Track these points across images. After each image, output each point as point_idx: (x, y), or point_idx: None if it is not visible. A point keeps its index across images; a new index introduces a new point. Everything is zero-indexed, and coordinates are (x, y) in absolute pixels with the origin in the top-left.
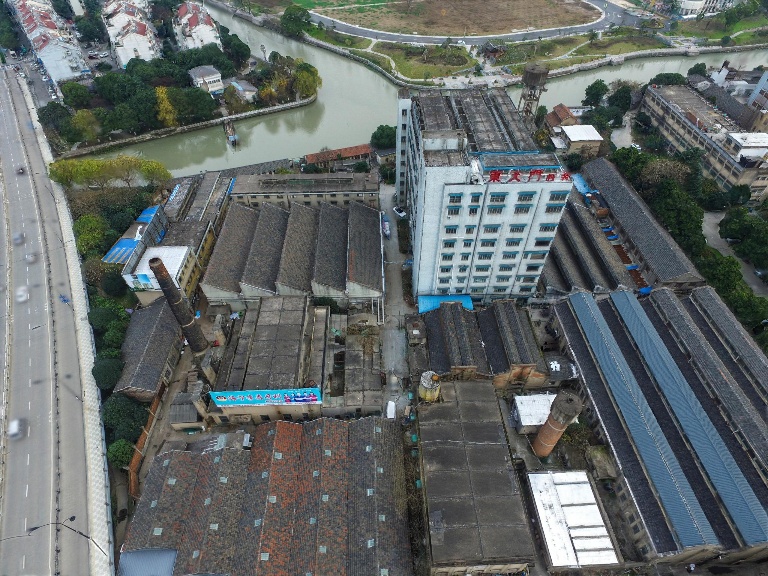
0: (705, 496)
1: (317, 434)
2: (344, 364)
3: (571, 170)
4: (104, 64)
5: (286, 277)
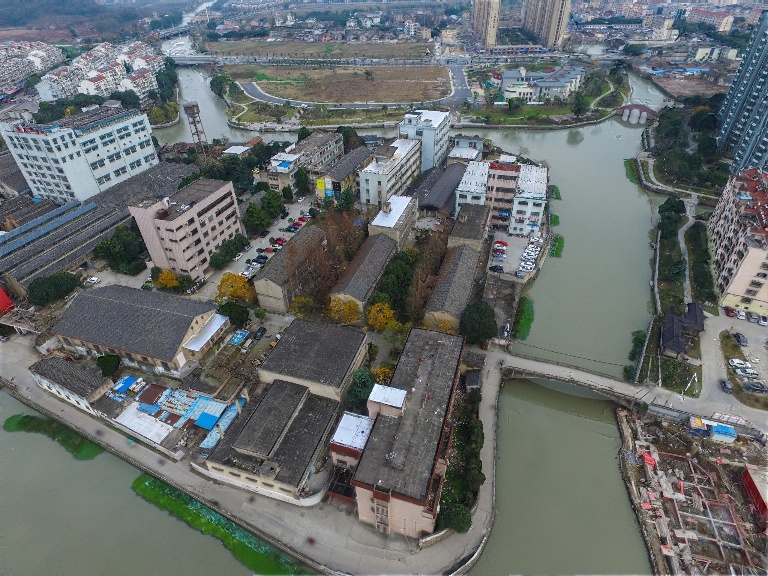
0: None
1: None
2: None
3: None
4: None
5: None
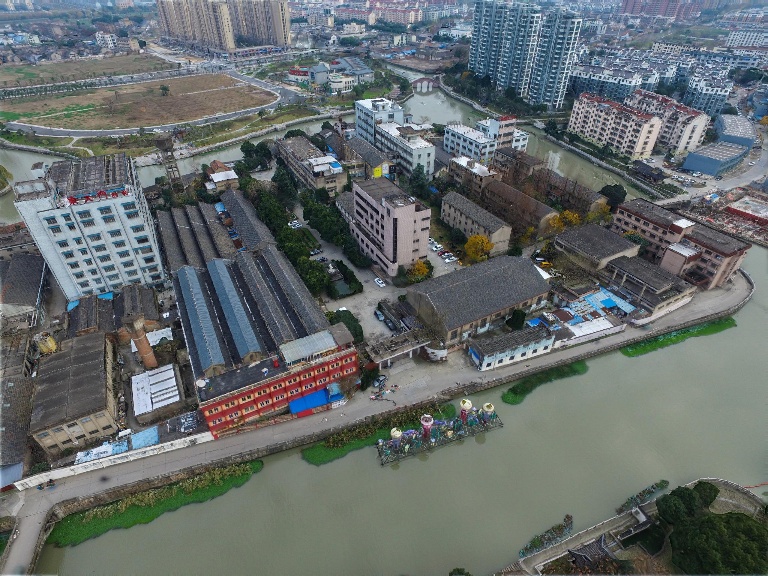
0: (233, 348)
1: None
2: None
3: None
4: None
5: None
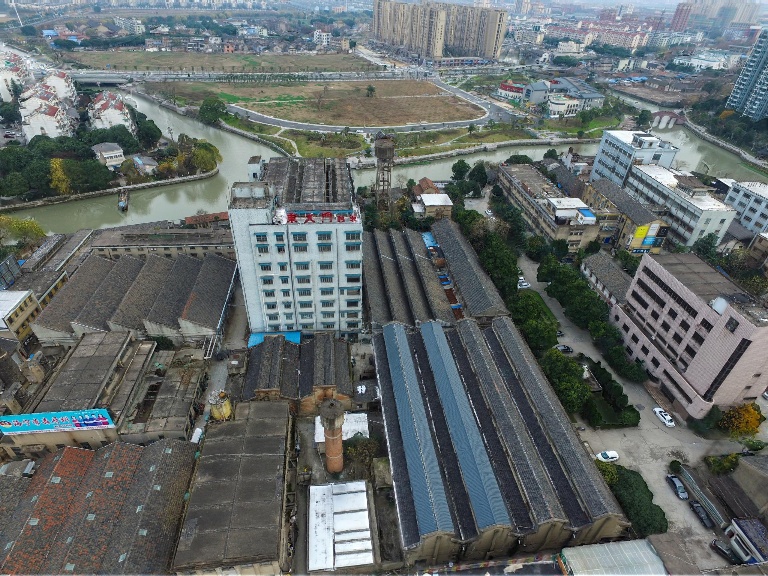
0: (460, 493)
1: (104, 458)
2: (157, 394)
3: (427, 230)
4: (14, 141)
5: (121, 317)
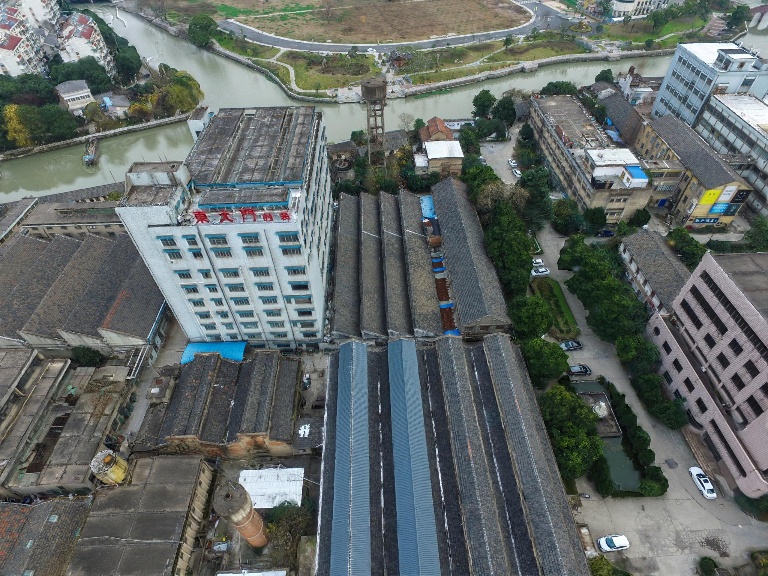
0: None
1: None
2: (62, 430)
3: (430, 190)
4: None
5: (36, 324)
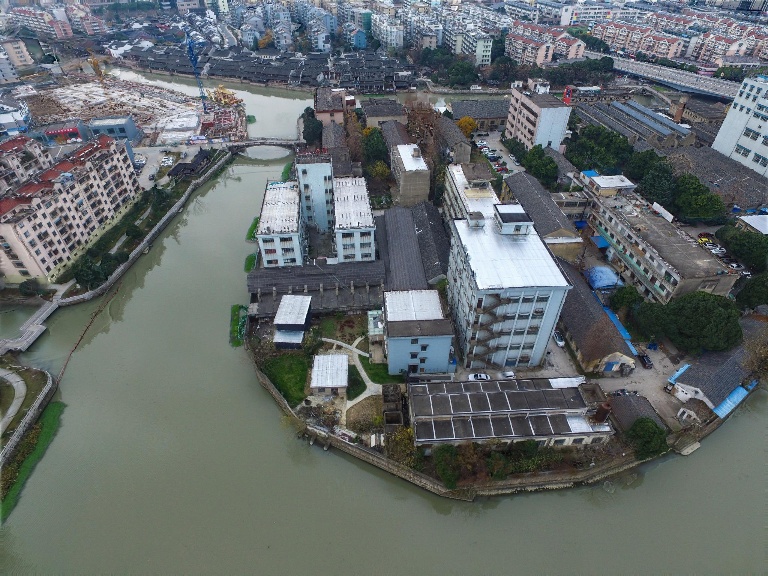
0: None
1: None
2: None
3: None
4: None
5: None
